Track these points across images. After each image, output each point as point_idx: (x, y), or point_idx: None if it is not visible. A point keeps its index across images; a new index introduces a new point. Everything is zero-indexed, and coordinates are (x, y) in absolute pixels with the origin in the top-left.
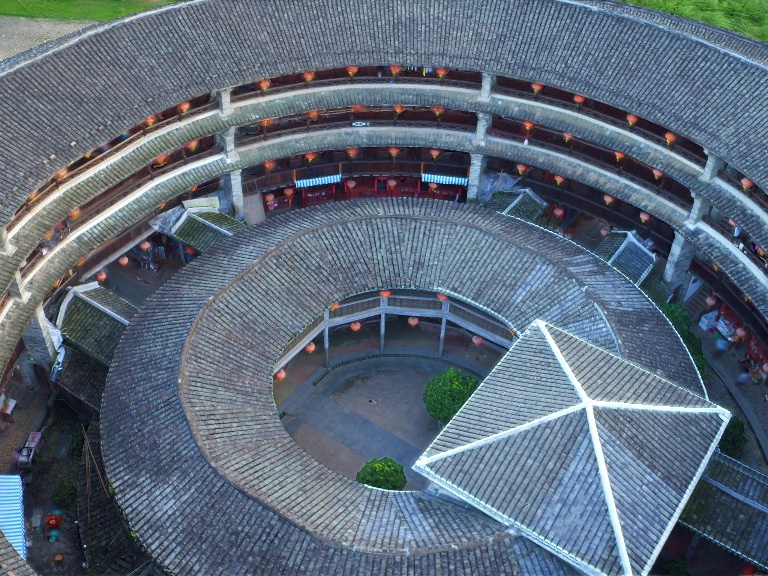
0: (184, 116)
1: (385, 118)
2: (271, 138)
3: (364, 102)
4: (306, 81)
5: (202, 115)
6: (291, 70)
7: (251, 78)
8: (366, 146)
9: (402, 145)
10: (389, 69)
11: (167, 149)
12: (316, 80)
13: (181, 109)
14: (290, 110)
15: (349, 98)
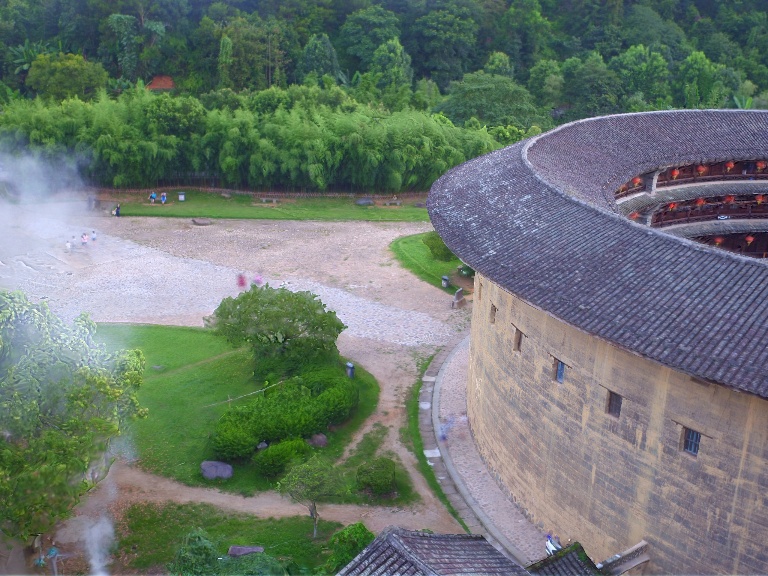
0: (628, 193)
1: (741, 213)
2: (665, 226)
3: (740, 191)
4: (694, 176)
5: (637, 194)
6: (700, 159)
7: (678, 161)
8: (735, 232)
9: (762, 230)
10: (754, 166)
11: (630, 212)
12: (700, 176)
13: (635, 182)
14: (691, 195)
15: (727, 189)
